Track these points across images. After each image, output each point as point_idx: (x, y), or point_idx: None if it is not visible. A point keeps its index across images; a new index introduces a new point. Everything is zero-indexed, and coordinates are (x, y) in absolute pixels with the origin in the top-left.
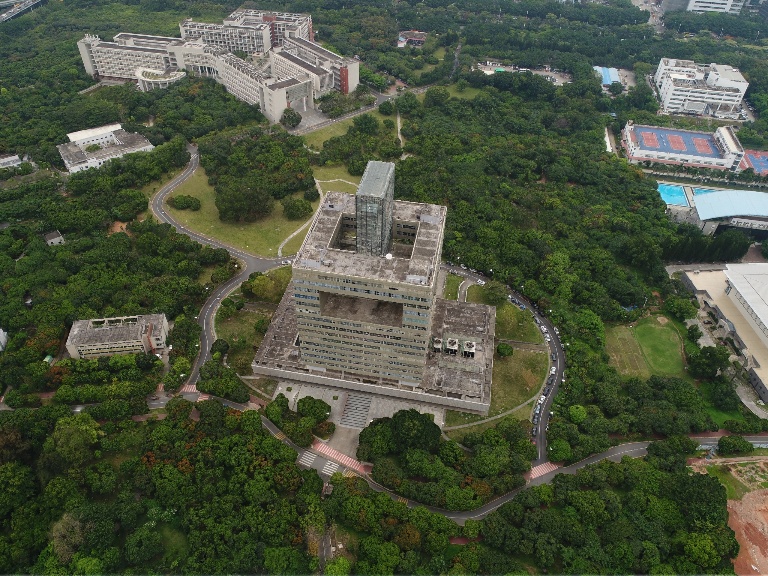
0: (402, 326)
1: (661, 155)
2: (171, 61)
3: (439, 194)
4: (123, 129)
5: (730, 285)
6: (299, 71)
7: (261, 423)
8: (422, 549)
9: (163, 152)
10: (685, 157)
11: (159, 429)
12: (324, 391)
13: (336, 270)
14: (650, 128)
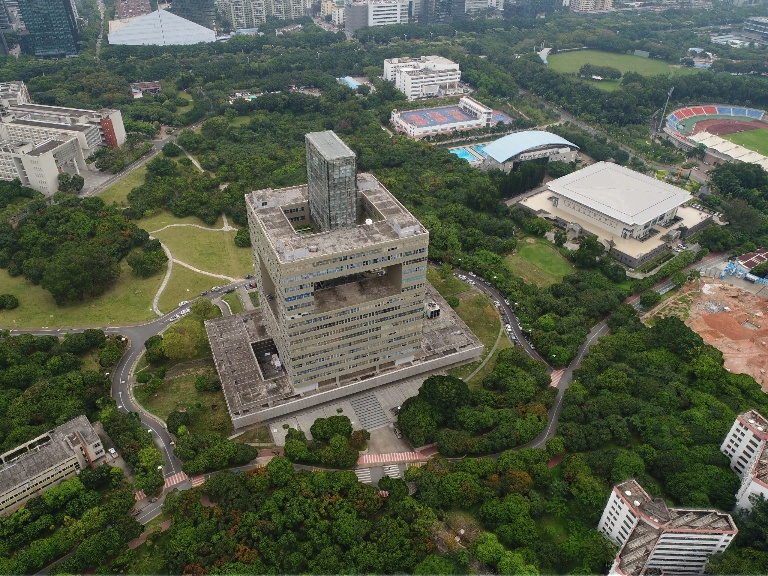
0: (401, 291)
1: (435, 128)
2: None
3: None
4: None
5: (558, 197)
6: (51, 134)
7: None
8: (534, 486)
9: None
10: (452, 125)
11: (179, 535)
12: (323, 410)
13: (327, 251)
14: (411, 112)
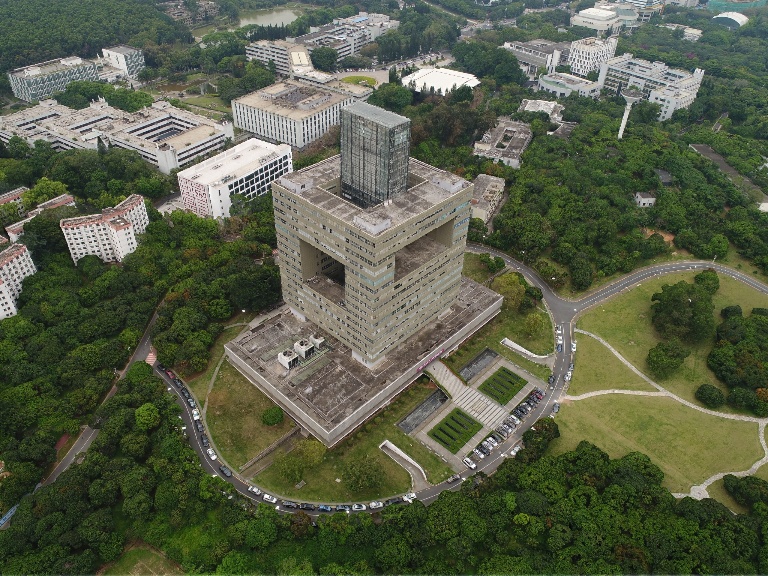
0: None
1: None
2: None
3: (666, 562)
4: None
5: None
6: None
7: None
8: None
9: None
10: None
11: None
12: None
13: None
14: None
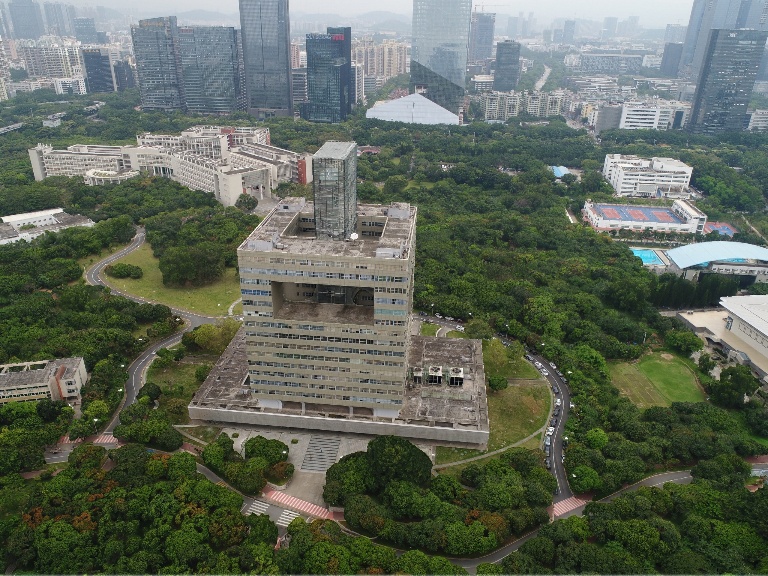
0: (374, 322)
1: (625, 224)
2: (125, 163)
3: None
4: (64, 212)
5: (730, 317)
6: None
7: (196, 468)
8: None
9: (106, 227)
10: (649, 225)
11: (54, 480)
12: (280, 435)
13: (291, 252)
14: (609, 206)
